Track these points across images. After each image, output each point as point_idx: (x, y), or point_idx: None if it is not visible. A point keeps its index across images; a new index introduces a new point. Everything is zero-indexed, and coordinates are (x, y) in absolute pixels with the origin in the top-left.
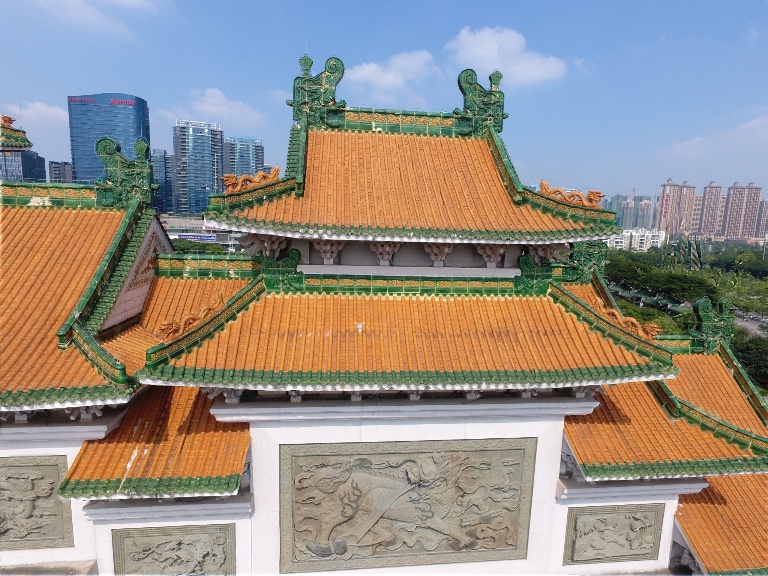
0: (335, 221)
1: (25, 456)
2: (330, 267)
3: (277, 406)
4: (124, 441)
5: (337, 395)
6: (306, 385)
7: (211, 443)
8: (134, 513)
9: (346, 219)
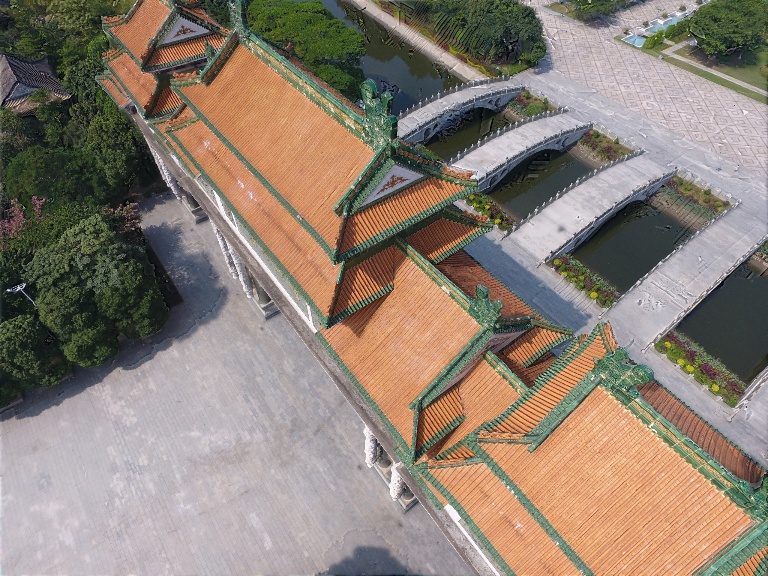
0: (528, 491)
1: None
2: None
3: None
4: None
5: None
6: None
7: None
8: None
9: (537, 493)
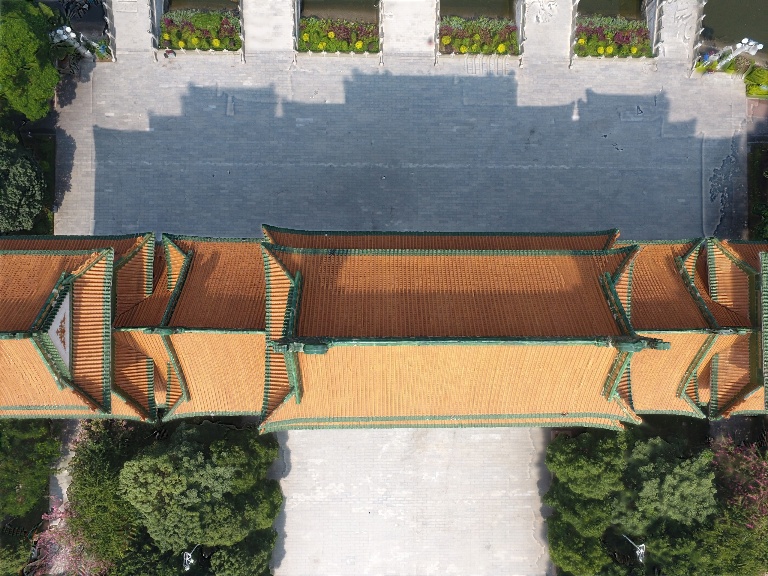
0: None
1: None
2: None
3: None
4: None
5: None
6: None
7: None
8: None
9: None
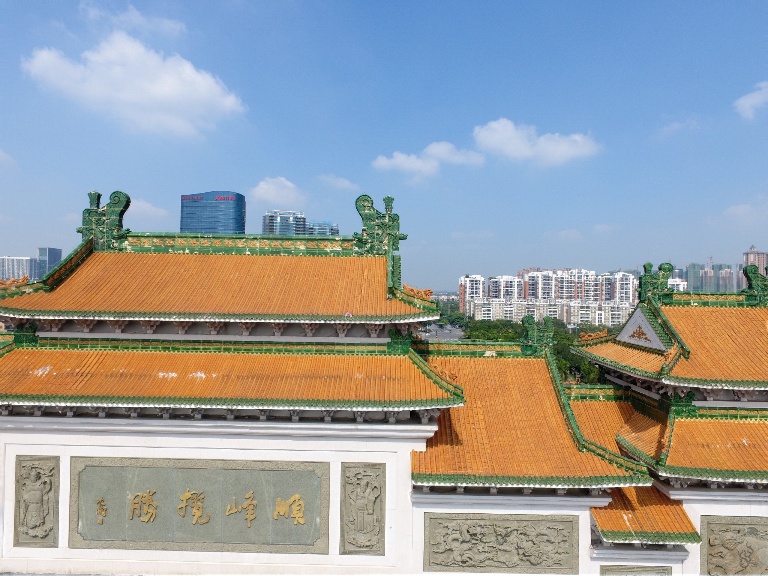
0: (724, 377)
1: (557, 515)
2: (712, 402)
3: (707, 490)
4: (614, 508)
5: (730, 484)
6: (740, 479)
7: (664, 512)
8: (621, 554)
9: None
